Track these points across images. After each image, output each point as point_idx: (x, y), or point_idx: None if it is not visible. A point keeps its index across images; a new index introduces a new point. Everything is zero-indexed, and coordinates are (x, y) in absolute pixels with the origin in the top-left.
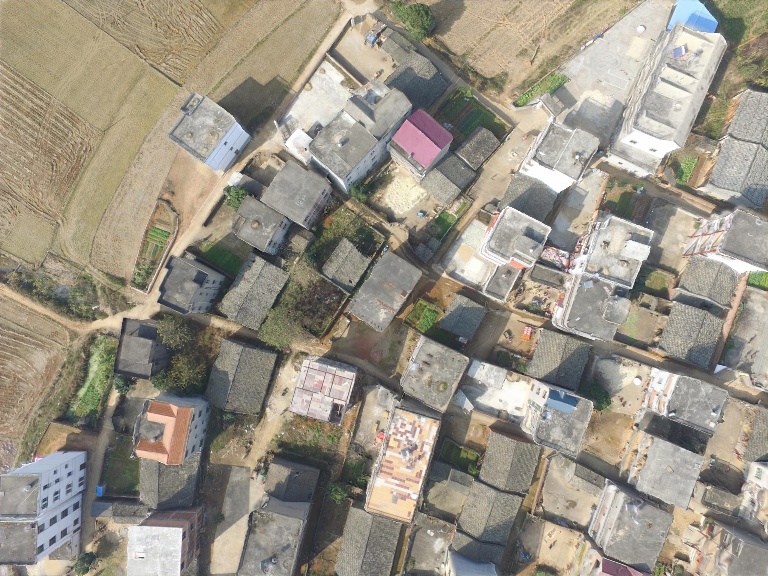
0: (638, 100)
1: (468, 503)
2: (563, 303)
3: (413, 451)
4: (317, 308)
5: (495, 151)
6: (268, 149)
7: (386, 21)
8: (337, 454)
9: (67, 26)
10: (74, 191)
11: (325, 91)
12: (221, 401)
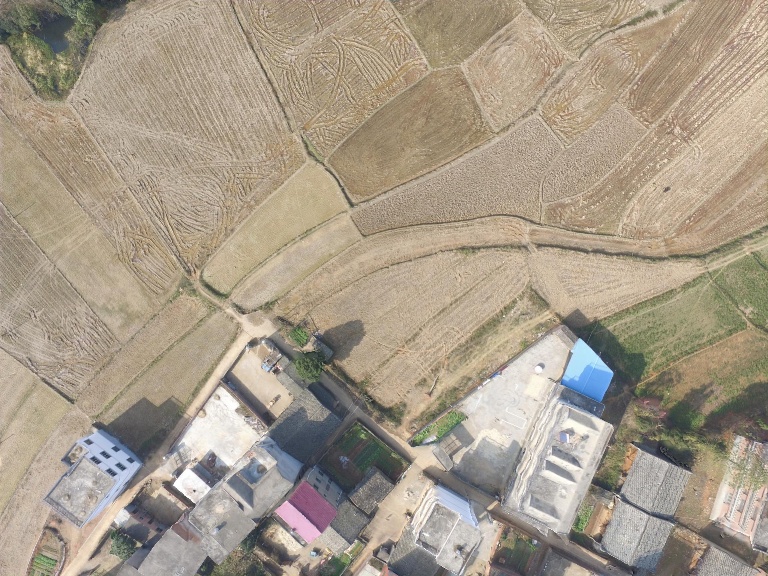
0: (527, 470)
1: None
2: None
3: None
4: None
5: None
6: (160, 476)
7: (284, 344)
8: None
9: None
10: None
11: (219, 418)
12: None
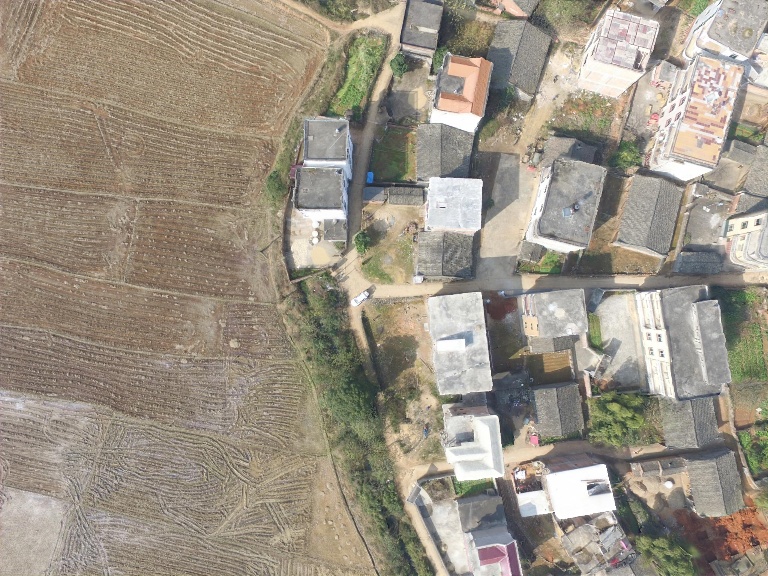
0: None
1: (754, 168)
2: None
3: None
4: None
5: None
6: None
7: None
8: (608, 139)
9: None
10: None
11: None
12: (503, 75)
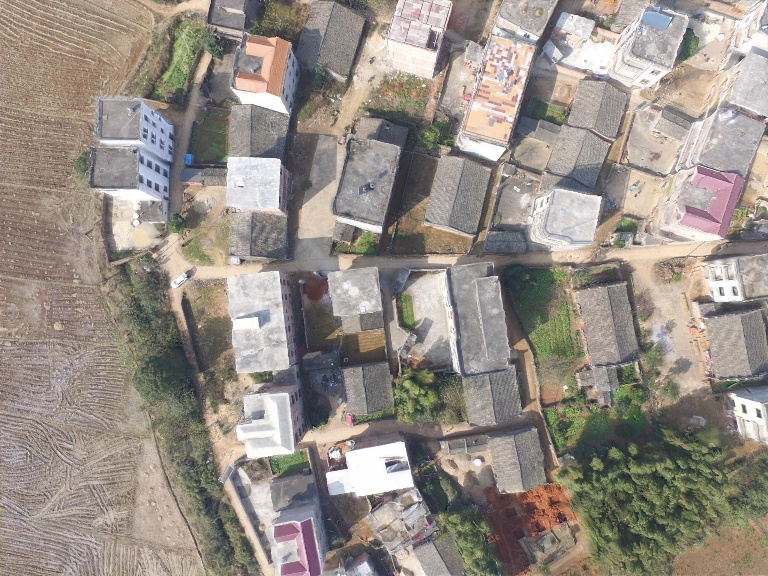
0: None
1: (557, 148)
2: None
3: (509, 76)
4: None
5: None
6: None
7: None
8: (424, 120)
9: None
10: None
11: None
12: (313, 56)
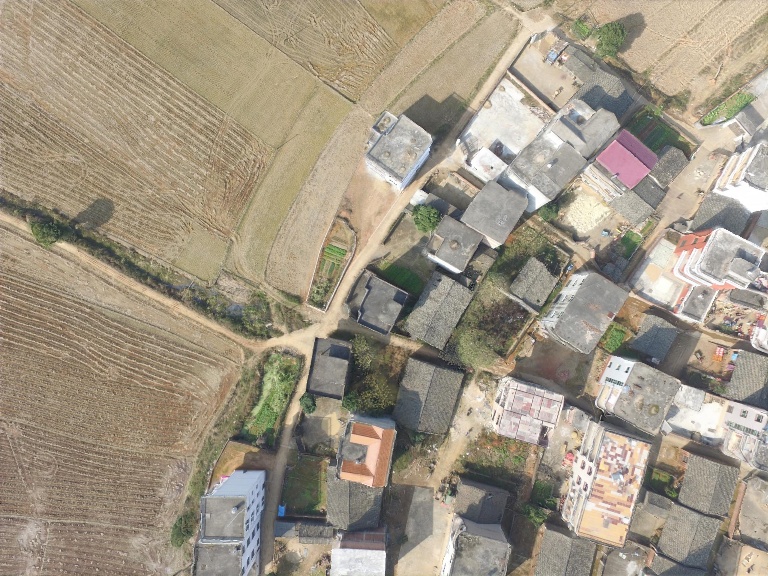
0: None
1: (668, 526)
2: (764, 324)
3: (624, 475)
4: (500, 327)
5: (681, 170)
6: (446, 167)
7: (565, 38)
8: (523, 475)
9: (240, 43)
10: (248, 208)
11: (505, 109)
12: (413, 422)
